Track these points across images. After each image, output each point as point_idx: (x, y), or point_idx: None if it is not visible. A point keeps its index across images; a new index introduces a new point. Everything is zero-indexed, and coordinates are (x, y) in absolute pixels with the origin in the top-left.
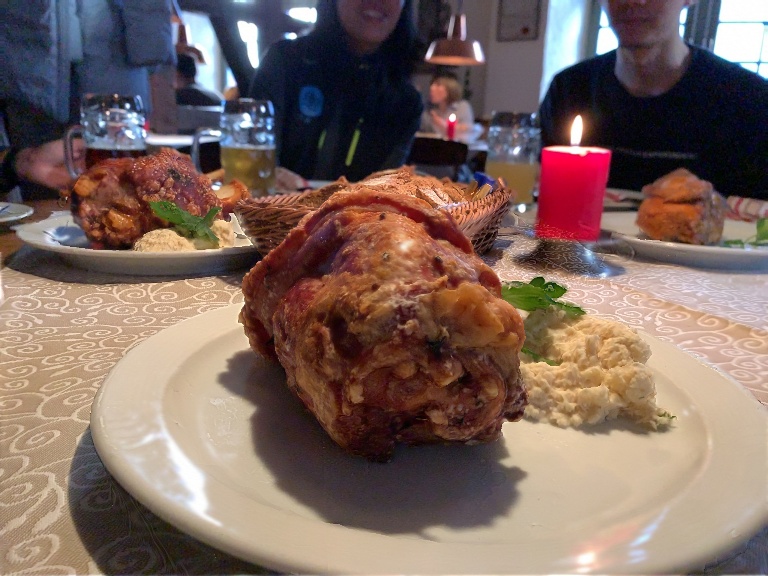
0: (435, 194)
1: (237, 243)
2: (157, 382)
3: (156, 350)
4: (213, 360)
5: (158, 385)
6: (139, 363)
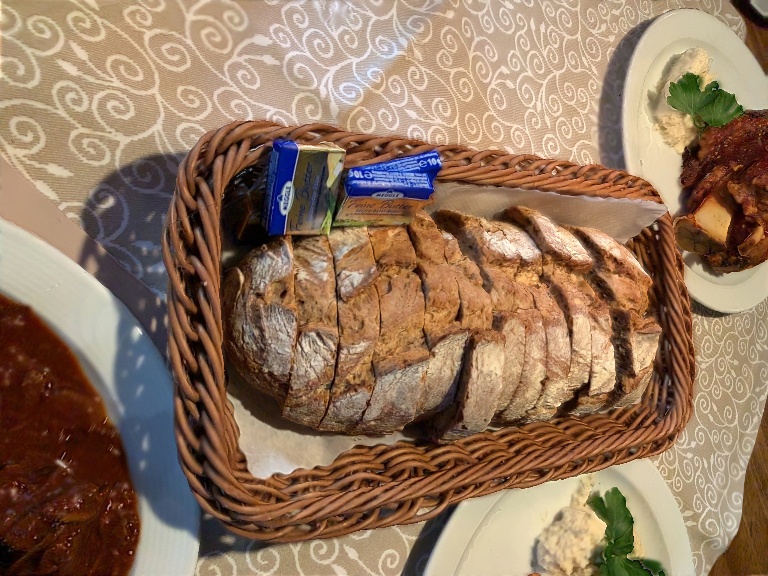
0: (506, 250)
1: (526, 551)
2: (764, 270)
3: (756, 293)
4: (732, 277)
5: (764, 268)
6: (765, 287)
